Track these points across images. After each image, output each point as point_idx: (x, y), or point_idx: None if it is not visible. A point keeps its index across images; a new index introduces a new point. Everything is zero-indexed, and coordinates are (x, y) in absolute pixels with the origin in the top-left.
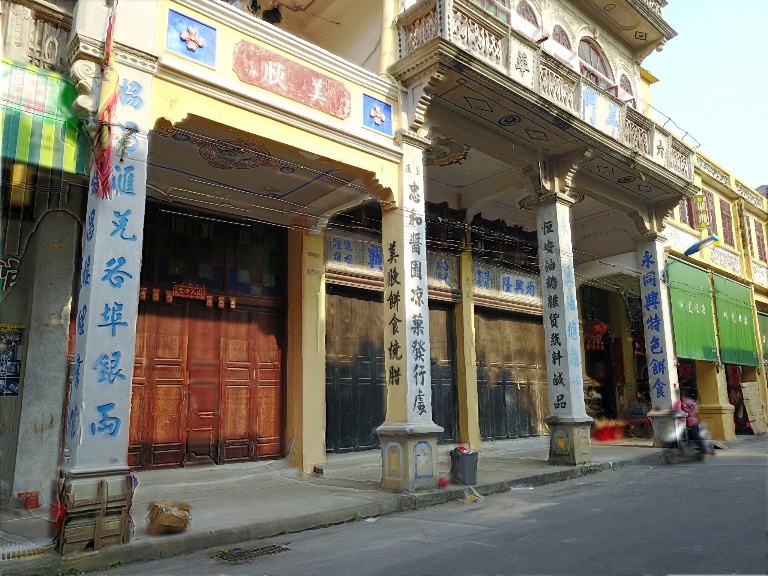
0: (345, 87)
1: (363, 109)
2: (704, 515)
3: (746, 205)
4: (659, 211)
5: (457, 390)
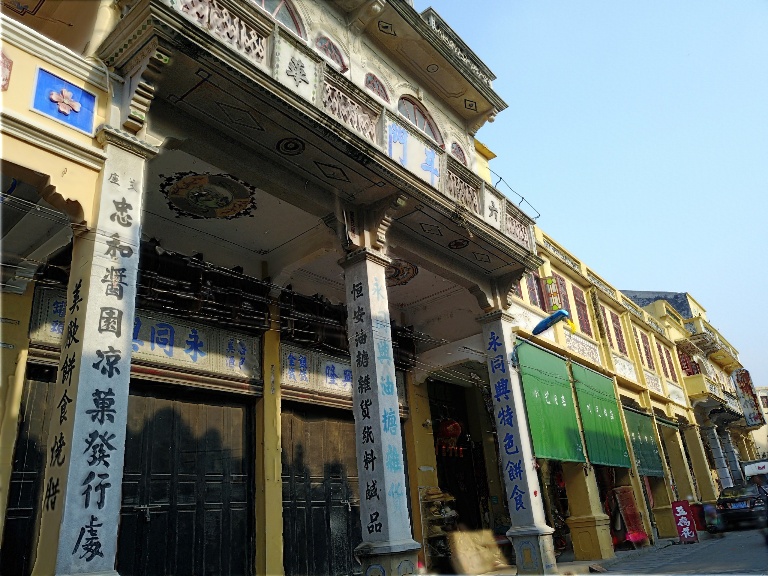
0: (3, 52)
1: (37, 88)
2: None
3: (600, 294)
4: (502, 286)
5: (254, 516)
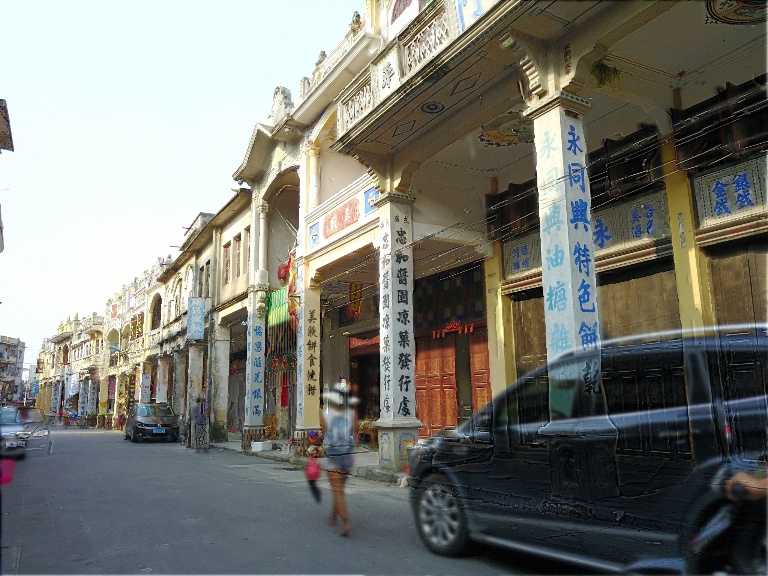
0: (357, 198)
1: (365, 203)
2: (235, 500)
3: None
4: None
5: None
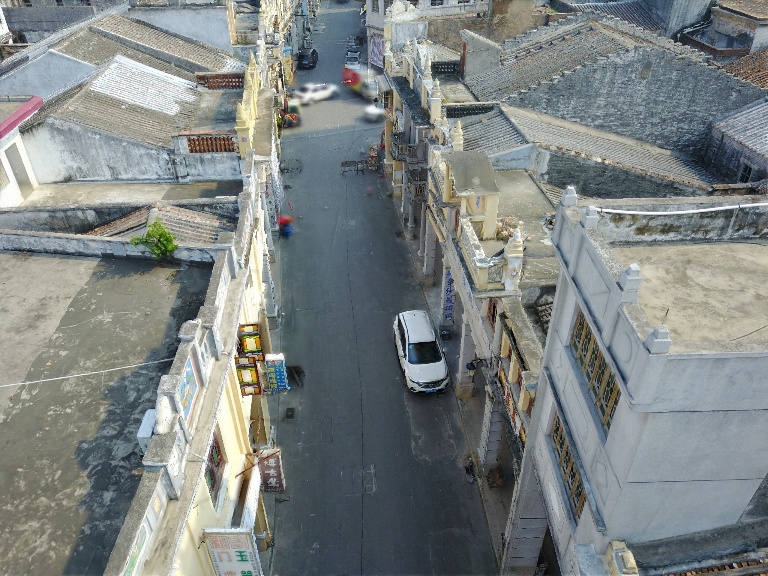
0: None
1: None
2: None
3: None
4: None
5: None
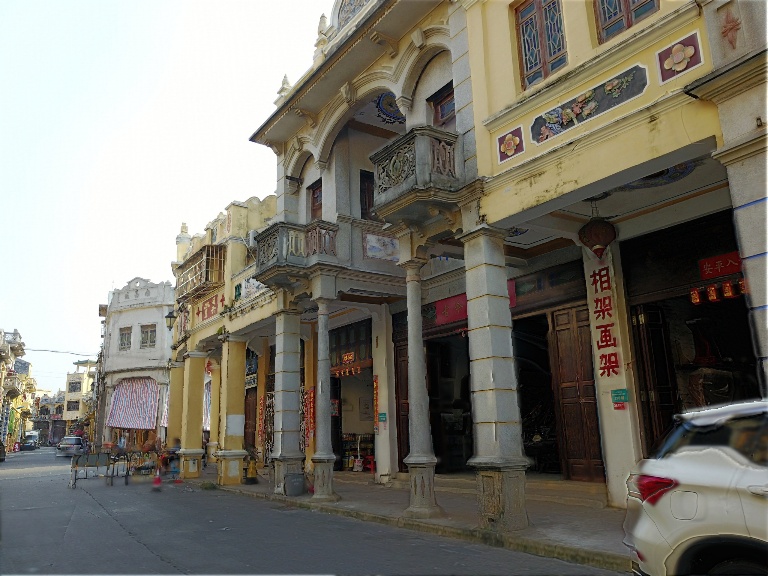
0: None
1: None
2: None
3: None
4: (13, 397)
5: None
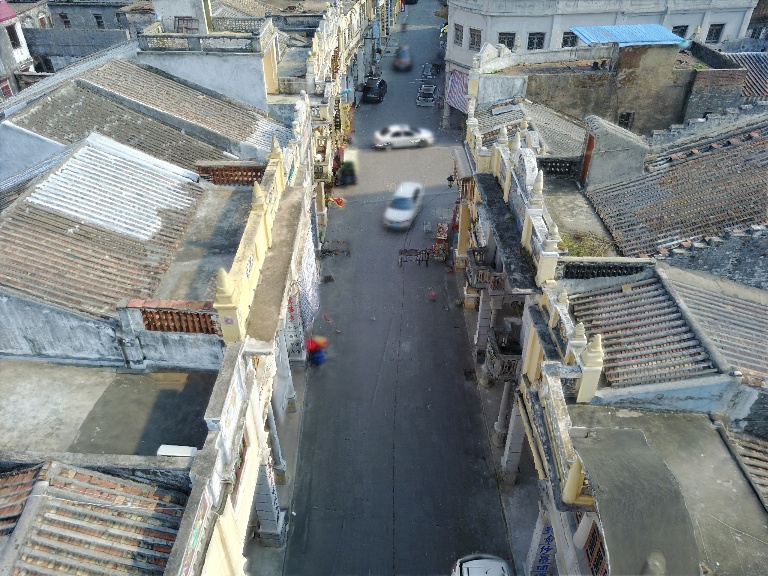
0: None
1: None
2: (413, 42)
3: None
4: None
5: None
